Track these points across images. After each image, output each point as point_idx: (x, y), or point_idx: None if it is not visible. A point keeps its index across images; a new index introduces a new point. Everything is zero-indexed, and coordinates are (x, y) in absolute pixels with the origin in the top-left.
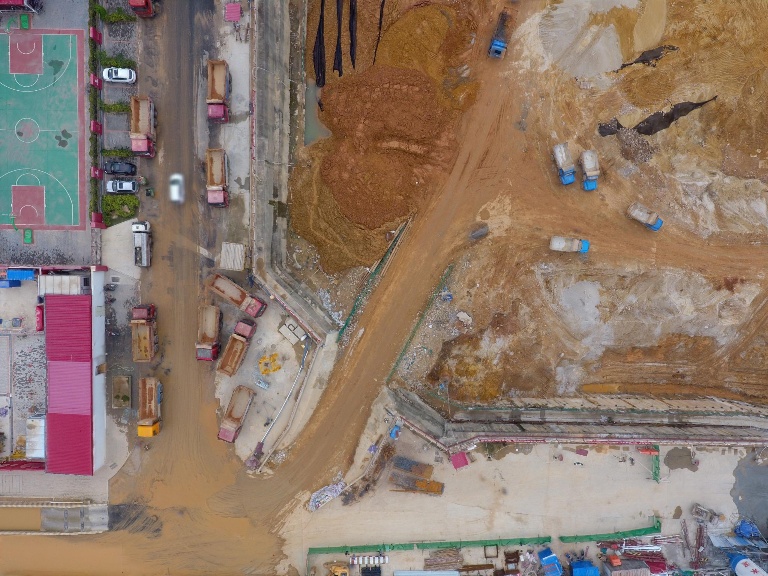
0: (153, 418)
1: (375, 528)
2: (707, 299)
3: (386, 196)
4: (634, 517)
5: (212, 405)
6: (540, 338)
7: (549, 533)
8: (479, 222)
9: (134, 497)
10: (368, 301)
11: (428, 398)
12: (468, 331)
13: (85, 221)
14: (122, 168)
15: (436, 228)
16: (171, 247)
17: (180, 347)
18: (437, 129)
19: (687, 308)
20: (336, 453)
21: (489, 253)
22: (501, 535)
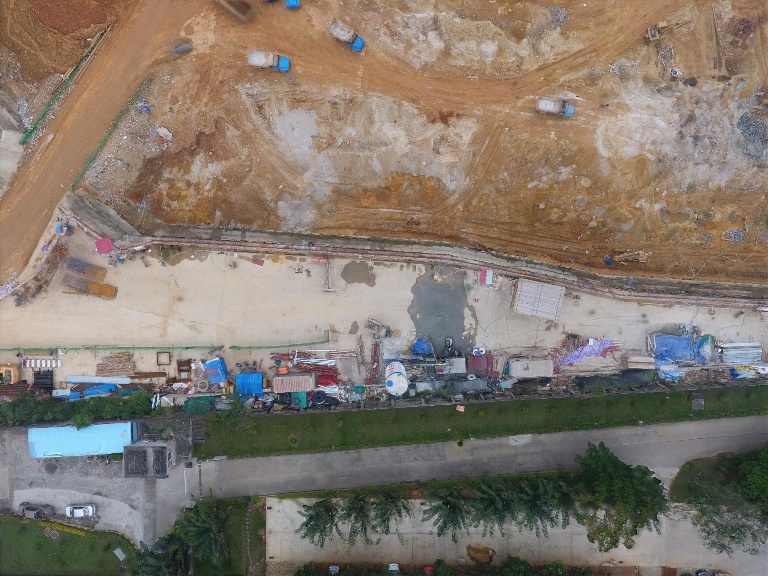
0: None
1: (49, 331)
2: (421, 132)
3: None
4: (310, 330)
5: None
6: (252, 164)
7: (223, 343)
8: (183, 37)
9: None
10: (60, 107)
11: (127, 214)
12: (168, 147)
13: None
14: None
15: (136, 40)
16: None
17: None
18: None
19: (401, 140)
20: (13, 254)
21: (192, 69)
22: (174, 343)
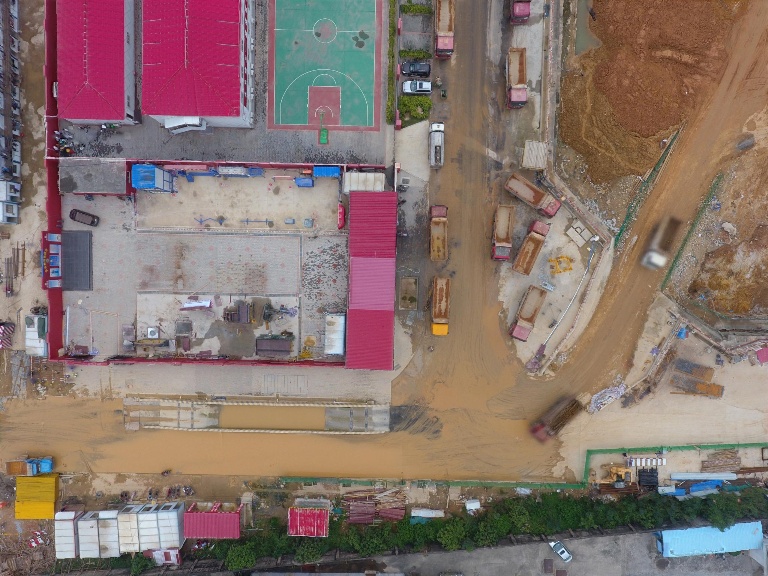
0: (444, 318)
1: (653, 430)
2: None
3: (665, 103)
4: None
5: (495, 308)
6: None
7: None
8: (745, 133)
9: (415, 398)
10: (641, 209)
11: (690, 308)
12: (732, 242)
13: (379, 122)
14: (423, 67)
15: (705, 138)
16: (460, 149)
17: (466, 249)
18: (710, 38)
19: None
20: (614, 357)
21: (754, 164)
22: None
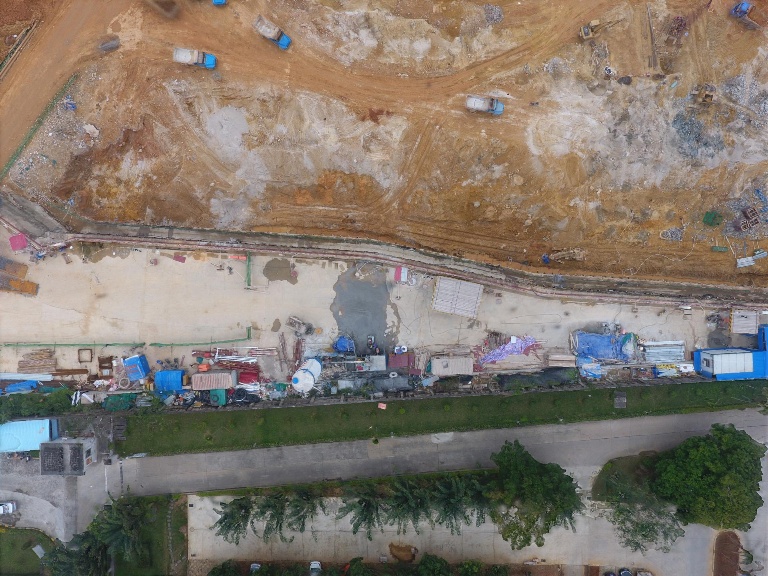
0: None
1: None
2: (351, 130)
3: None
4: (232, 328)
5: None
6: (181, 162)
7: (145, 340)
8: (110, 34)
9: None
10: None
11: (54, 211)
12: (95, 144)
13: None
14: None
15: (63, 36)
16: None
17: None
18: None
19: (331, 138)
20: None
21: (119, 66)
22: (96, 340)
